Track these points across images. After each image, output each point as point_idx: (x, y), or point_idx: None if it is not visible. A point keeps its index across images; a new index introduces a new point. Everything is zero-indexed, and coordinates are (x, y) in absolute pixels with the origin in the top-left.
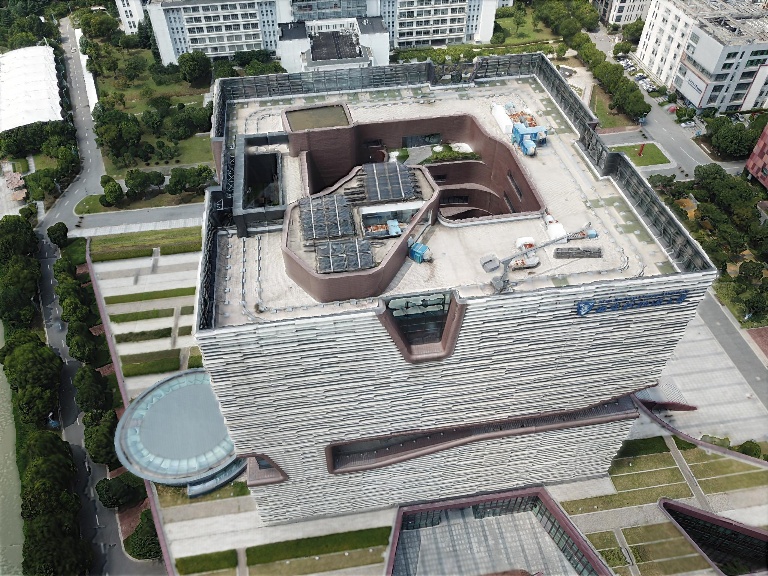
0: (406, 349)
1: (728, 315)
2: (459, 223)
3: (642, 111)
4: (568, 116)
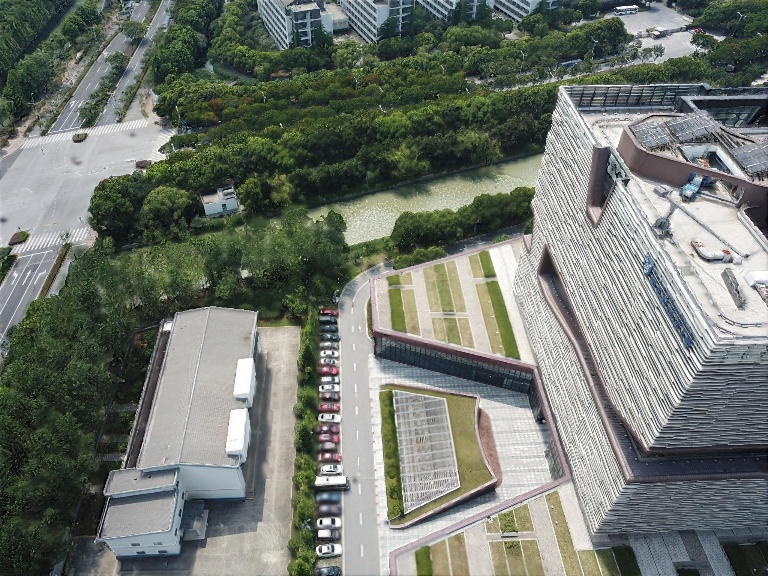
0: (590, 195)
1: None
2: (742, 216)
3: None
4: None
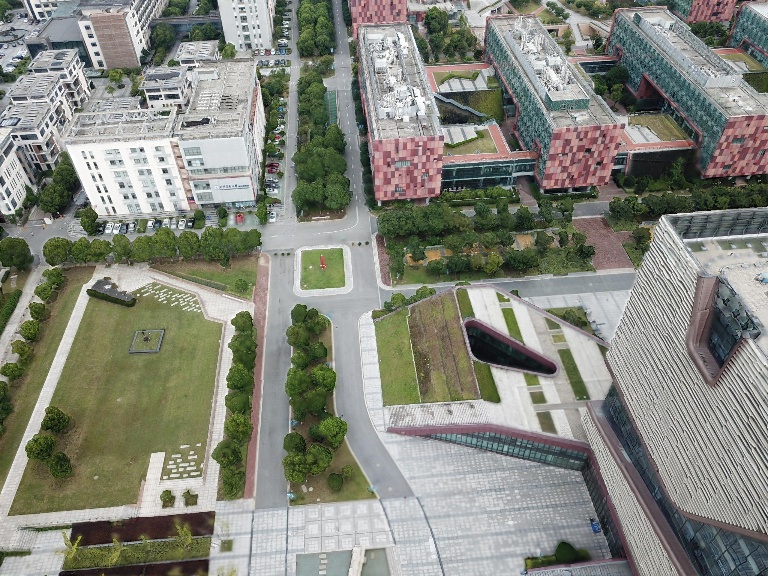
0: None
1: (578, 275)
2: None
3: (258, 239)
4: None
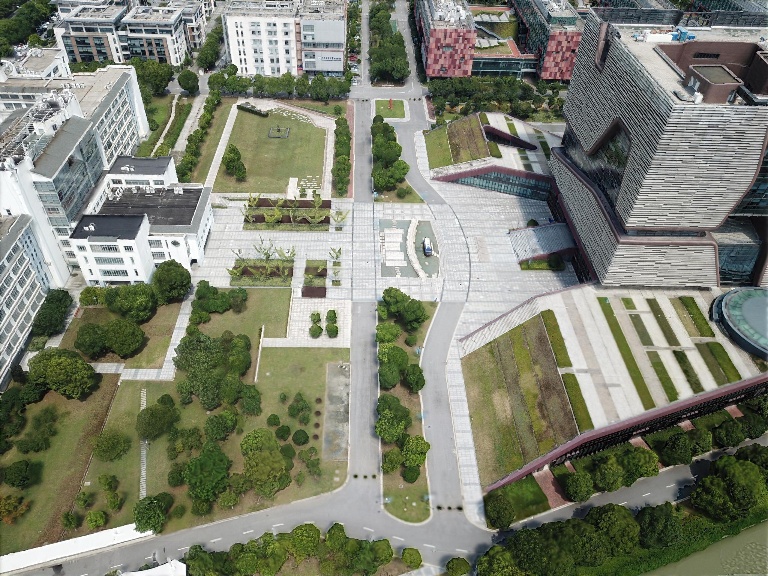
0: None
1: (559, 124)
2: None
3: (349, 87)
4: (648, 23)
